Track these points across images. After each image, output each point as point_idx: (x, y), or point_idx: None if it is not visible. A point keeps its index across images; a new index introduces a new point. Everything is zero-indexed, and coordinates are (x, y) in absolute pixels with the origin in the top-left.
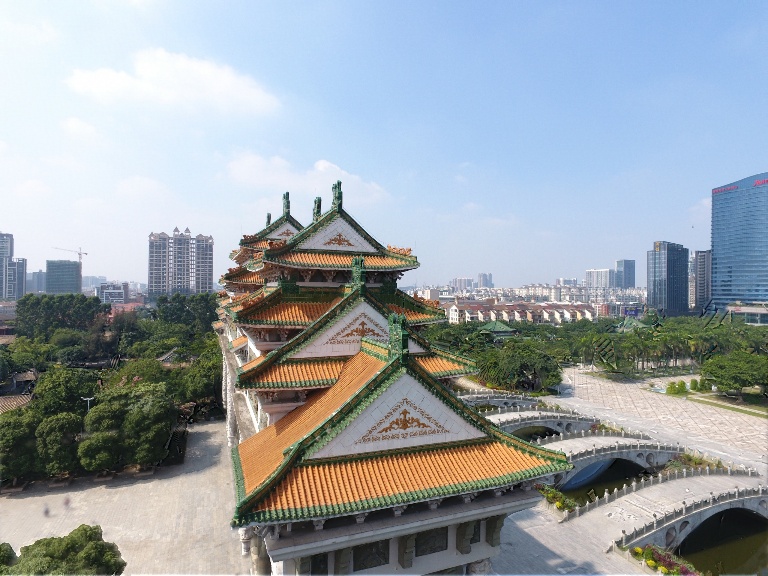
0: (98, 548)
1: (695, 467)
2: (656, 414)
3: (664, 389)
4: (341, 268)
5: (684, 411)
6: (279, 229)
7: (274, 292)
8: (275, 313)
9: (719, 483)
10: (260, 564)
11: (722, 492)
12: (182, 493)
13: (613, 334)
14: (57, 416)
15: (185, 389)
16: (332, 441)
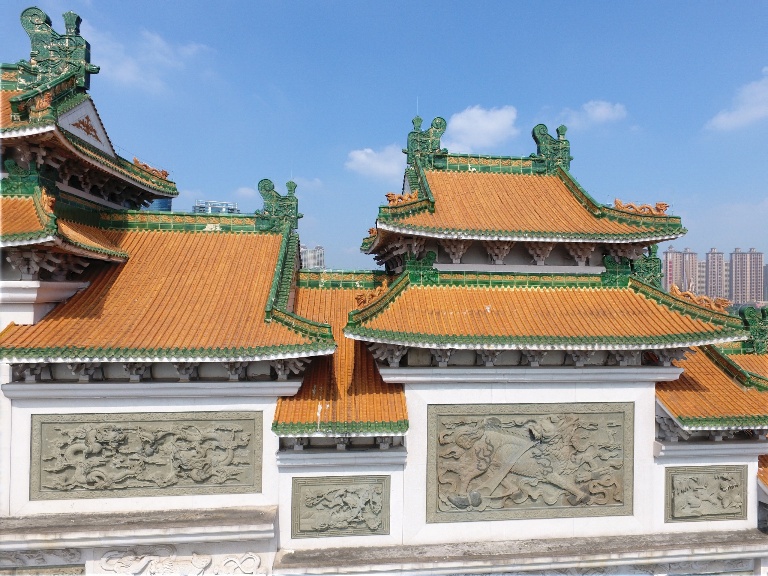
0: None
1: None
2: None
3: None
4: None
5: None
6: (75, 108)
7: None
8: None
9: None
10: None
11: None
12: None
13: None
14: None
15: None
16: None
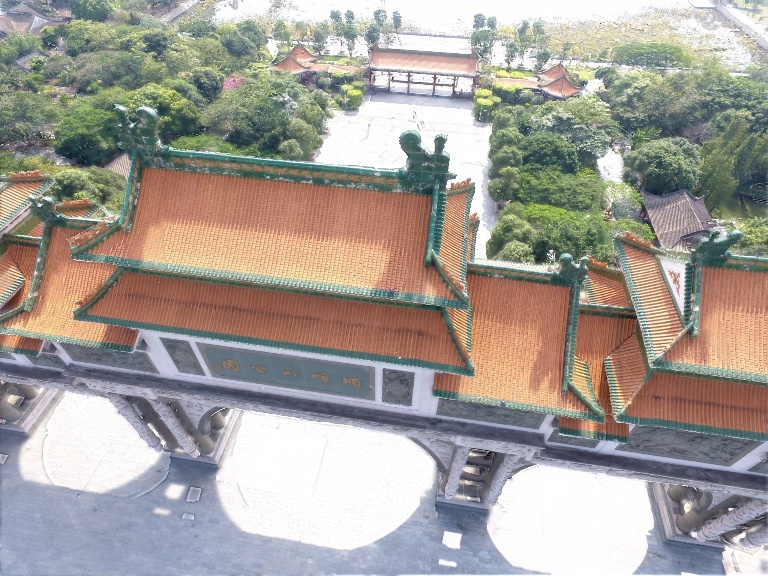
0: None
1: None
2: None
3: None
4: None
5: None
6: None
7: None
8: None
9: None
10: None
11: None
12: None
13: None
14: (516, 246)
15: None
16: None
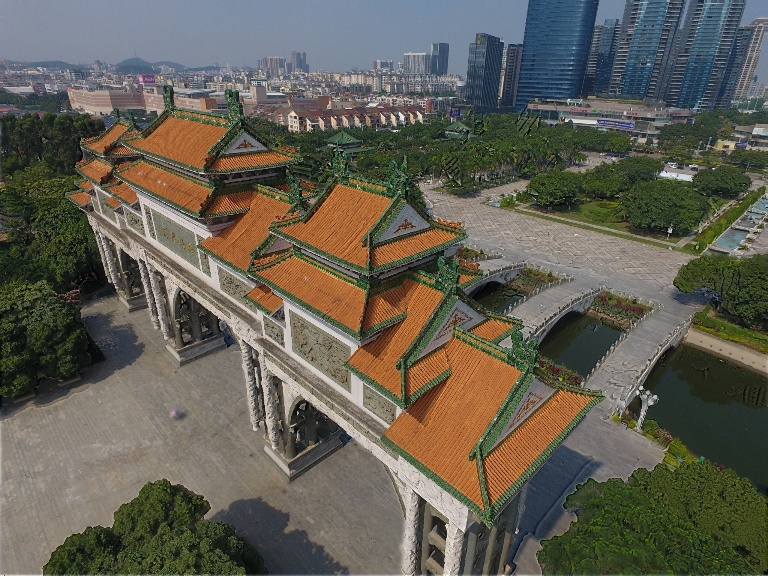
0: (185, 499)
1: (535, 278)
2: (499, 230)
3: (499, 203)
4: (418, 258)
5: (516, 224)
6: (236, 141)
7: (368, 294)
8: (374, 314)
9: (557, 294)
10: (288, 450)
11: (561, 302)
12: (134, 393)
13: (459, 152)
14: None
15: (50, 272)
16: (497, 438)
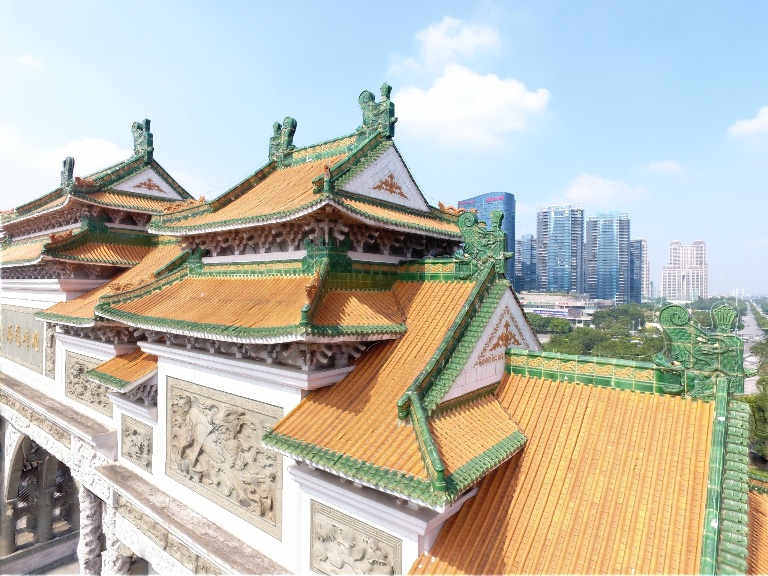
0: None
1: None
2: None
3: None
4: (418, 230)
5: None
6: (135, 176)
7: (325, 269)
8: (338, 311)
9: None
10: None
11: None
12: None
13: None
14: None
15: None
16: None
